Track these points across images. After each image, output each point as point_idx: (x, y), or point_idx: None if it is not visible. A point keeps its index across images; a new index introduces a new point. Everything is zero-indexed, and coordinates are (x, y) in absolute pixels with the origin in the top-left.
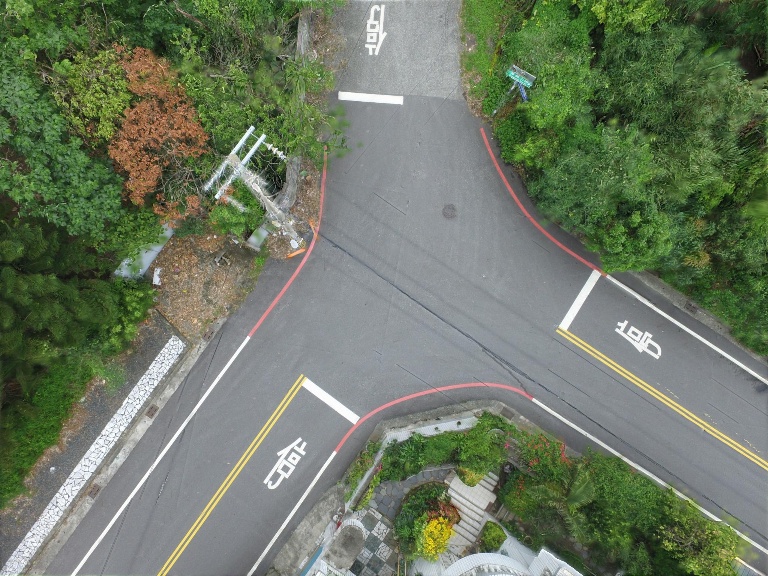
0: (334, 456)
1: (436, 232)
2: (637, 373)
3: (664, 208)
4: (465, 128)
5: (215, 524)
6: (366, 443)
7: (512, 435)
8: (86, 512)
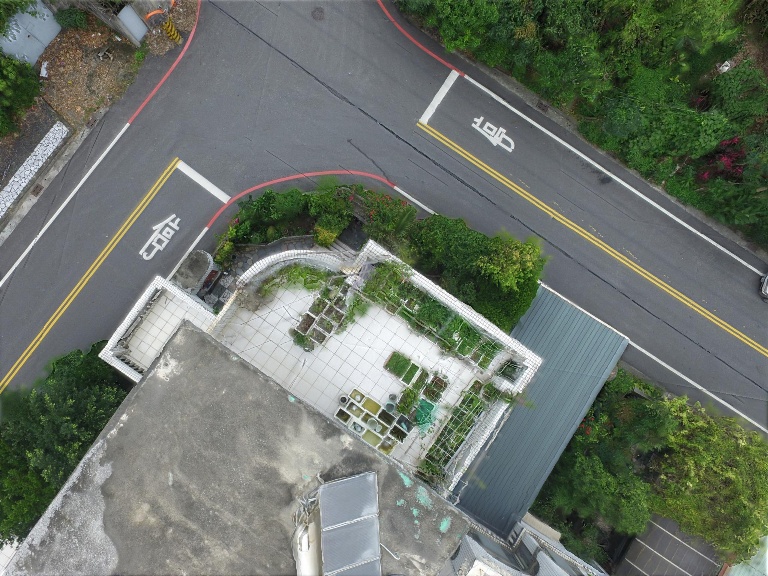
0: (206, 231)
1: (306, 32)
2: (492, 165)
3: None
4: None
5: (93, 290)
6: None
7: (359, 193)
8: None
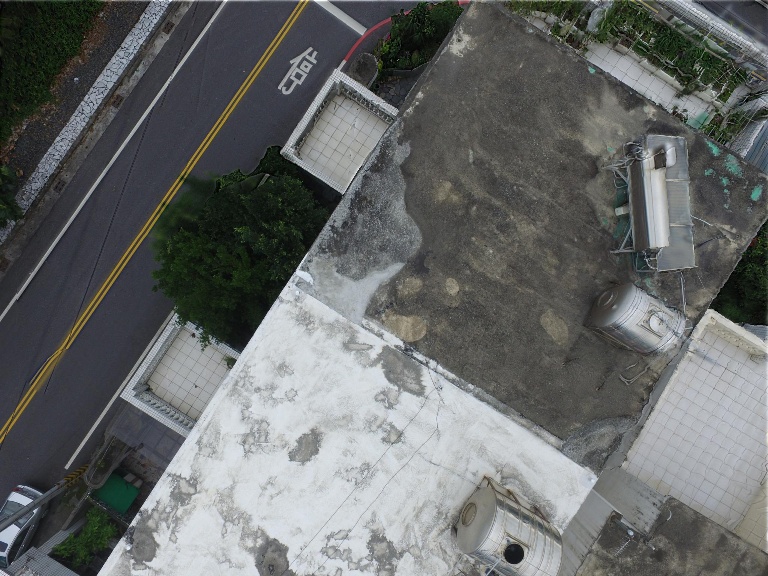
0: (344, 64)
1: None
2: None
3: None
4: None
5: (234, 127)
6: None
7: None
8: (111, 120)
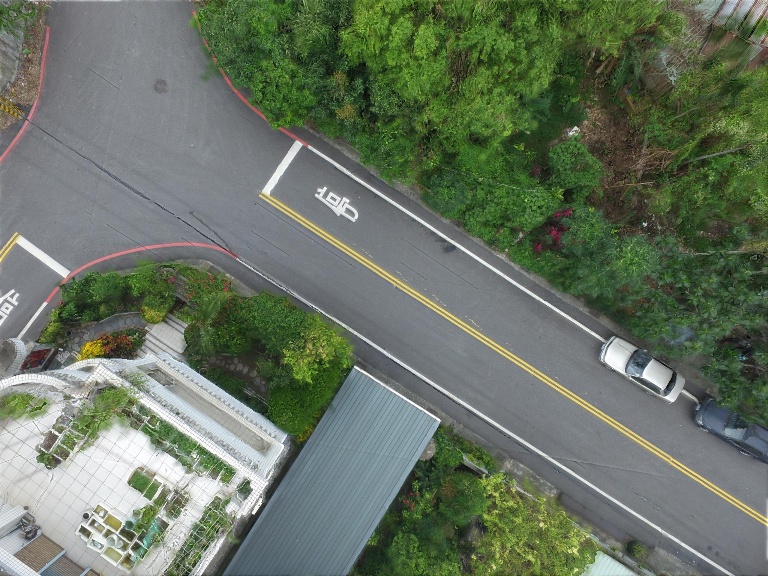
0: (45, 306)
1: (148, 105)
2: (335, 235)
3: (303, 61)
4: (178, 11)
5: None
6: None
7: (182, 273)
8: None
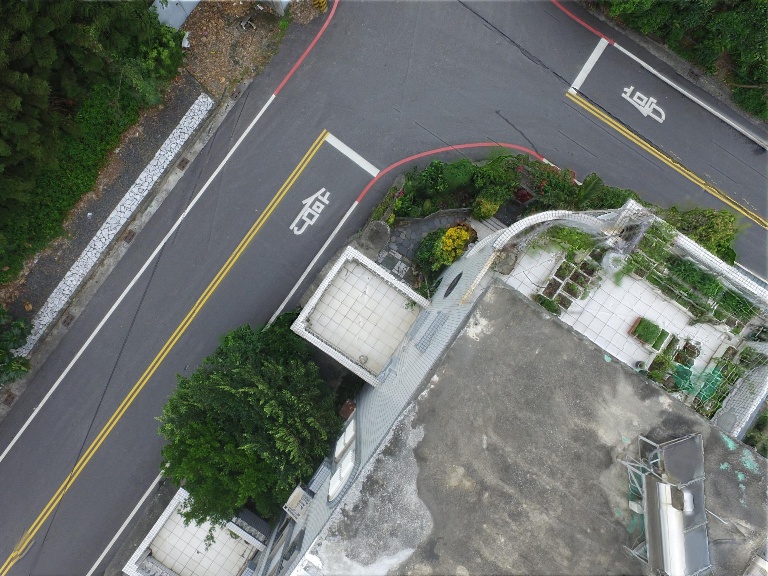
0: (356, 205)
1: None
2: None
3: None
4: None
5: (244, 266)
6: (386, 195)
7: (525, 163)
8: (122, 255)
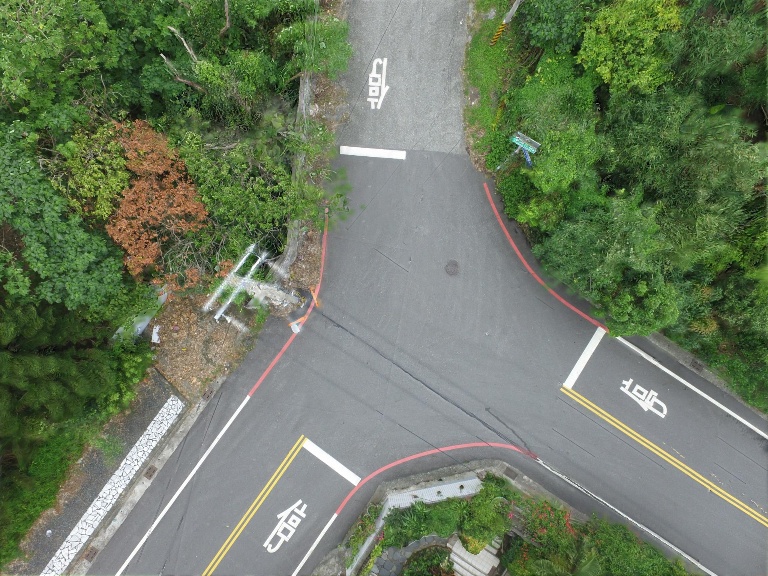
0: (335, 519)
1: (439, 289)
2: (642, 432)
3: (671, 276)
4: (468, 183)
5: None
6: (367, 505)
7: (516, 503)
8: (83, 575)
